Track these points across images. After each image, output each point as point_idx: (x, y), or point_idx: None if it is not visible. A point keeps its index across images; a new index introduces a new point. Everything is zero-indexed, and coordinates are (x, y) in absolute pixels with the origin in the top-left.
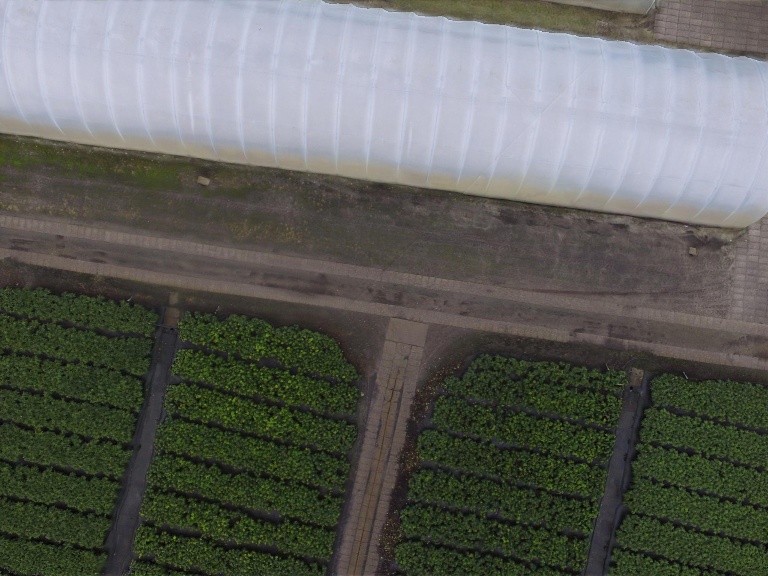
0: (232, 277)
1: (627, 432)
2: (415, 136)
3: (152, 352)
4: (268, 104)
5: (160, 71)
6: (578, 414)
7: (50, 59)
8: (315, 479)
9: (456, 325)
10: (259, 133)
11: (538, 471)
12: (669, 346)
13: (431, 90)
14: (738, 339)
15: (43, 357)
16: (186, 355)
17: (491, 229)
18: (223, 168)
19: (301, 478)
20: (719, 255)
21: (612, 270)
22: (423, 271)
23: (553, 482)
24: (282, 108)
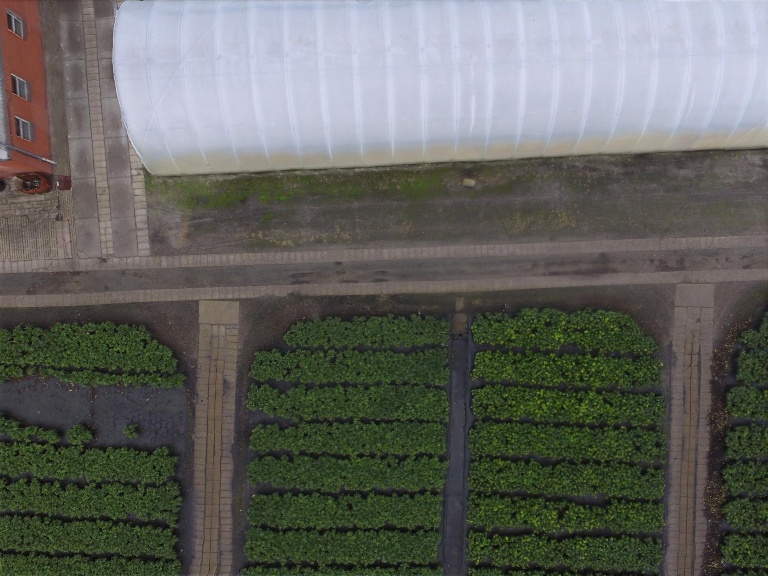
0: (515, 272)
1: None
2: (697, 99)
3: (448, 361)
4: (552, 92)
5: (444, 78)
6: None
7: (334, 86)
8: (636, 455)
9: (741, 280)
10: (538, 124)
11: None
12: None
13: (713, 50)
14: None
15: (345, 385)
16: (486, 357)
17: (757, 180)
18: (485, 167)
19: (622, 457)
20: None
21: None
22: (699, 233)
23: None
24: (565, 94)
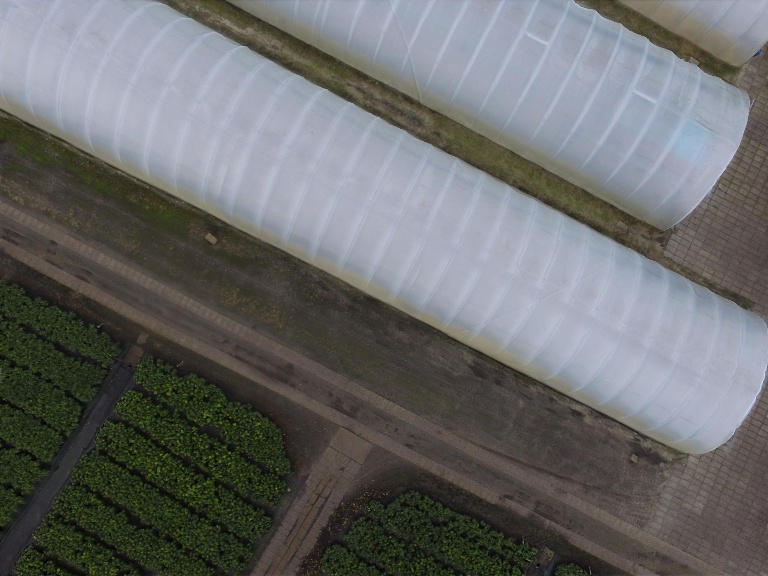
0: (206, 338)
1: None
2: (420, 277)
3: (103, 382)
4: (296, 202)
5: (206, 137)
6: (482, 575)
7: (106, 88)
8: (215, 558)
9: (399, 454)
10: (278, 221)
11: None
12: (585, 538)
13: (448, 244)
14: (648, 552)
15: None
16: (135, 398)
17: (461, 376)
18: (234, 233)
19: (202, 552)
20: (656, 470)
21: (557, 451)
22: (386, 394)
23: None
24: (307, 209)
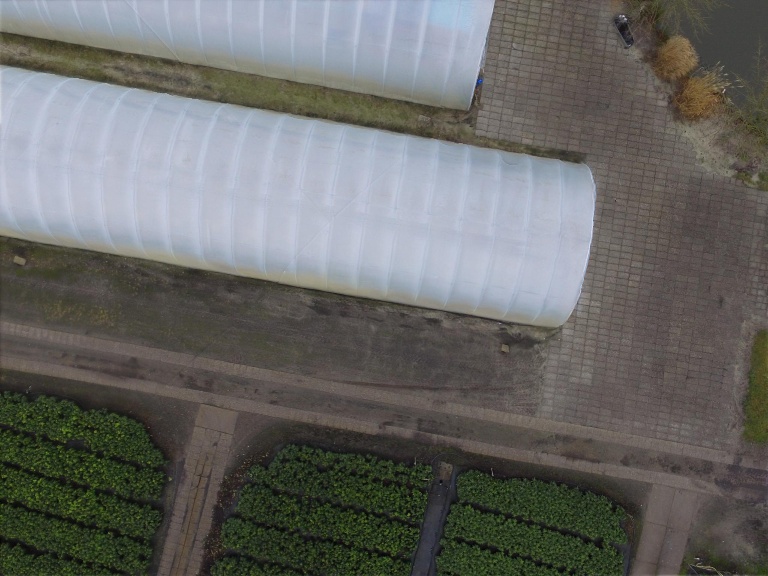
0: (44, 358)
1: (435, 525)
2: (213, 233)
3: None
4: (65, 197)
5: None
6: (383, 507)
7: None
8: (116, 563)
9: (266, 414)
10: (62, 222)
11: (340, 563)
12: (478, 442)
13: (225, 190)
14: (547, 438)
15: None
16: None
17: (305, 319)
18: (40, 249)
19: (102, 562)
20: (532, 353)
21: (424, 364)
22: (235, 359)
23: (355, 574)
24: (80, 201)
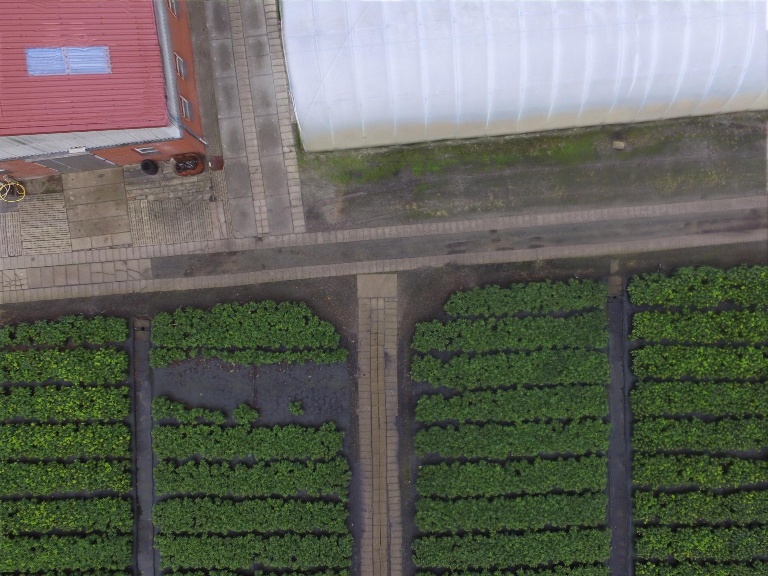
0: (668, 232)
1: None
2: None
3: None
4: (714, 48)
5: (609, 38)
6: None
7: (501, 50)
8: None
9: None
10: (696, 81)
11: None
12: None
13: None
14: None
15: (507, 352)
16: (644, 318)
17: None
18: (633, 129)
19: None
20: None
21: None
22: None
23: None
24: (727, 49)
